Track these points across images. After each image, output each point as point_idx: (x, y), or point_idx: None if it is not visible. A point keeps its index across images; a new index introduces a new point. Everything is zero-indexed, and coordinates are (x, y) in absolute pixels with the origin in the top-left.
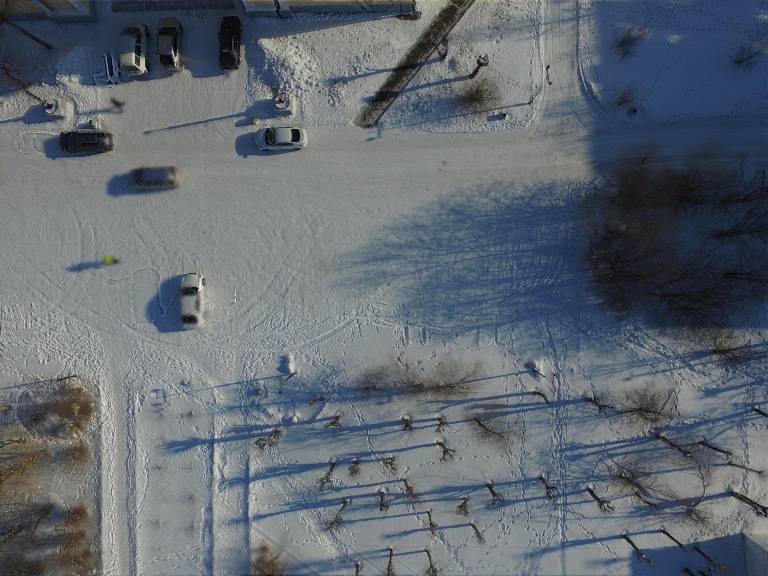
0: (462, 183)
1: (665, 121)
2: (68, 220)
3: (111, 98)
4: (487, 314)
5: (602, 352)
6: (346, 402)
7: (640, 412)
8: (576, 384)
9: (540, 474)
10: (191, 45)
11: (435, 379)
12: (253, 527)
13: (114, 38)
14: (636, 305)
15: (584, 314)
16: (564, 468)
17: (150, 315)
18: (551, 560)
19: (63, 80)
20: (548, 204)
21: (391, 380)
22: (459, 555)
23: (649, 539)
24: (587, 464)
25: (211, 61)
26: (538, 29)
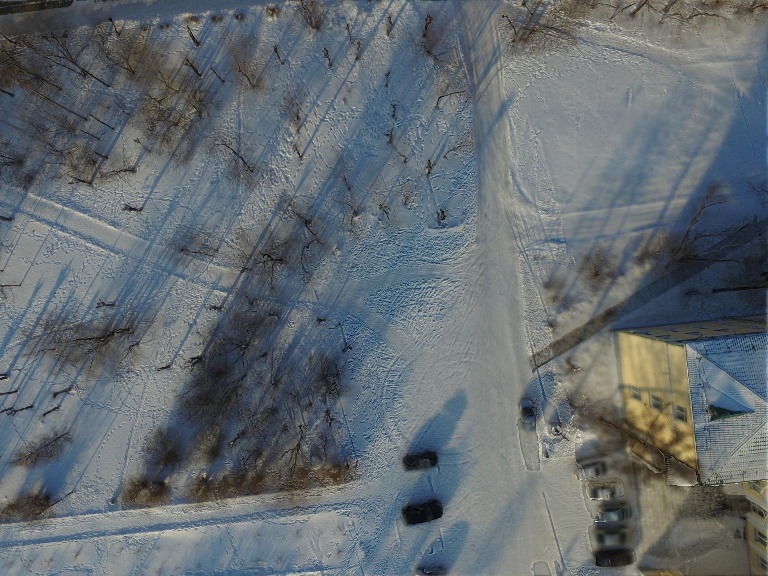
0: None
1: None
2: (472, 441)
3: (567, 466)
4: None
5: None
6: None
7: None
8: None
9: None
10: (612, 537)
11: None
12: None
13: None
14: None
15: None
16: None
17: None
18: None
19: (577, 434)
20: None
21: None
22: None
23: None
24: None
25: None
26: None
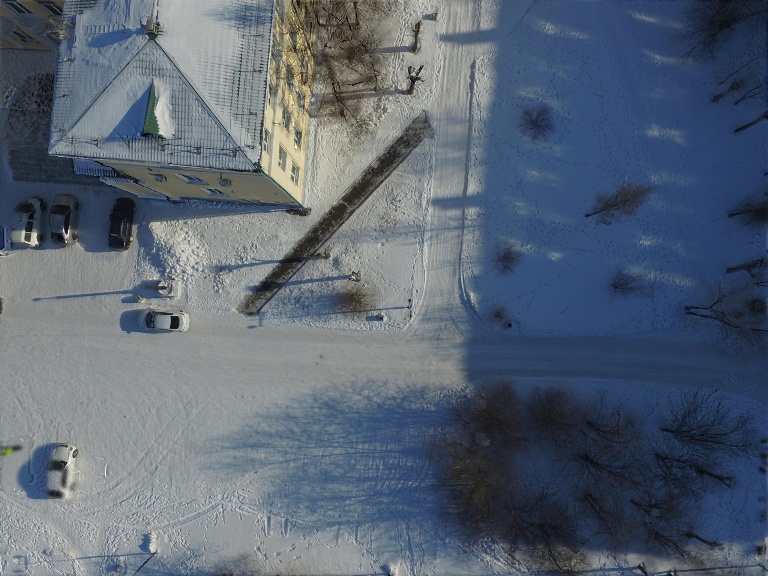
0: (337, 378)
1: (540, 336)
2: None
3: (4, 263)
4: (350, 511)
5: (458, 562)
6: None
7: None
8: None
9: None
10: (81, 226)
11: (292, 572)
12: None
13: (11, 208)
14: (495, 518)
15: (444, 521)
16: None
17: (16, 487)
18: None
19: None
20: (419, 407)
21: (249, 569)
22: None
23: None
24: None
25: (104, 237)
26: (423, 235)
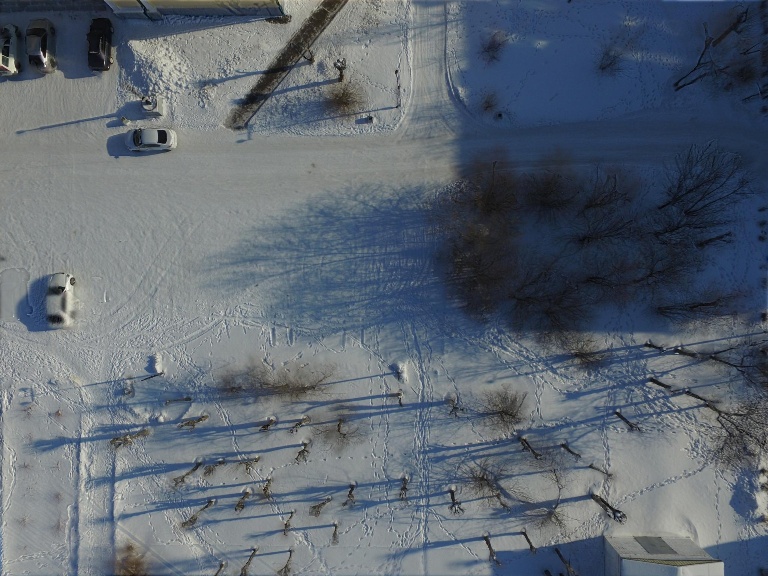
0: (331, 185)
1: (531, 126)
2: None
3: None
4: (354, 316)
5: (466, 354)
6: (212, 402)
7: (501, 414)
8: (440, 386)
9: (403, 475)
10: (59, 46)
11: (300, 380)
12: (118, 526)
13: None
14: (499, 308)
15: (449, 317)
16: (427, 470)
17: (15, 314)
18: (413, 561)
19: None
20: (415, 207)
21: (257, 381)
22: (322, 556)
23: (511, 541)
24: (450, 466)
25: (83, 62)
26: (406, 34)
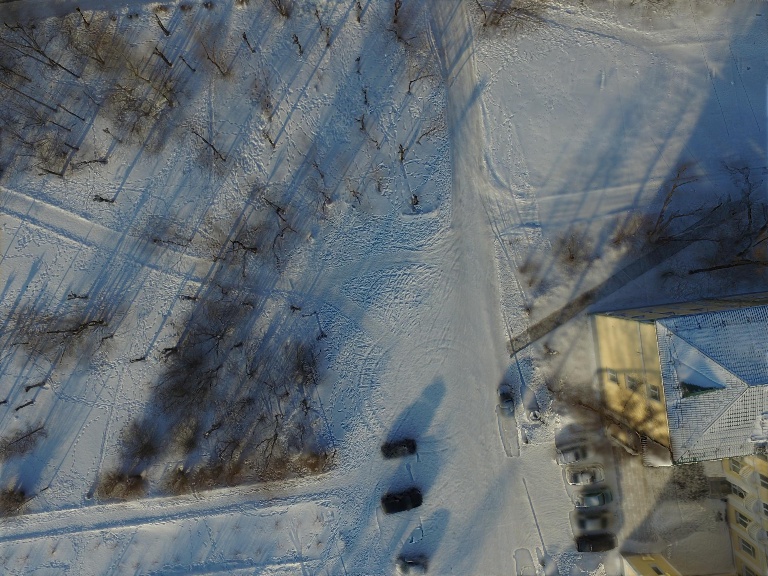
0: None
1: None
2: (451, 429)
3: (547, 451)
4: None
5: None
6: None
7: None
8: None
9: None
10: (593, 522)
11: None
12: None
13: None
14: None
15: None
16: None
17: None
18: None
19: (556, 419)
20: None
21: None
22: None
23: None
24: None
25: None
26: None
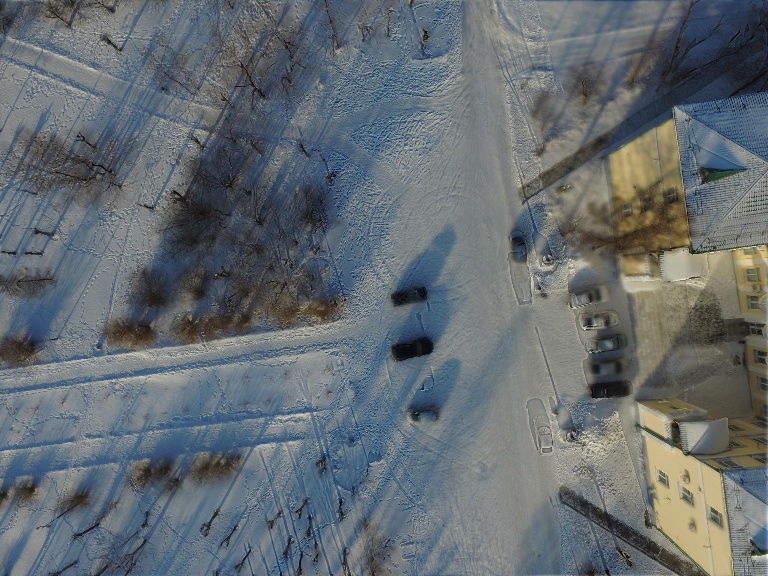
0: (526, 571)
1: None
2: (462, 277)
3: (560, 299)
4: None
5: None
6: (353, 505)
7: None
8: None
9: None
10: (607, 366)
11: (378, 569)
12: (252, 448)
13: None
14: None
15: None
16: None
17: (400, 359)
18: None
19: (569, 264)
20: None
21: (374, 537)
22: None
23: None
24: None
25: None
26: None
